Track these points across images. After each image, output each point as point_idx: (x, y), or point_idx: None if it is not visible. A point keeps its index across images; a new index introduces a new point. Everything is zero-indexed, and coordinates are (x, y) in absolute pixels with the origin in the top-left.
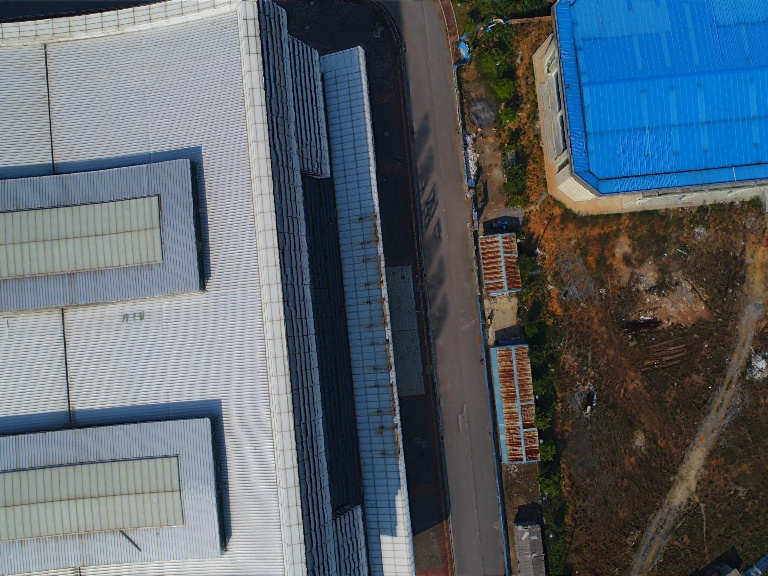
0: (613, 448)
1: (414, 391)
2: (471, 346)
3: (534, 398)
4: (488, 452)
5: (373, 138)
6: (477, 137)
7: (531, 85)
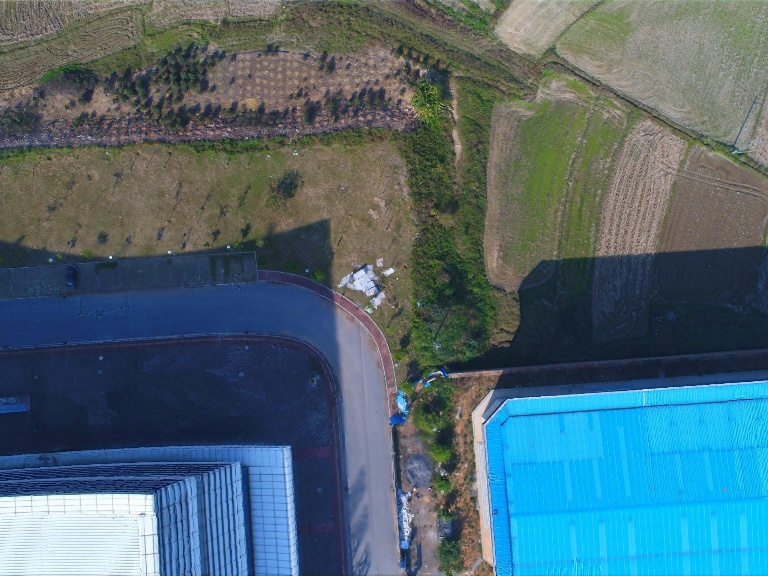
0: None
1: None
2: None
3: None
4: None
5: (297, 540)
6: (412, 496)
7: (469, 444)
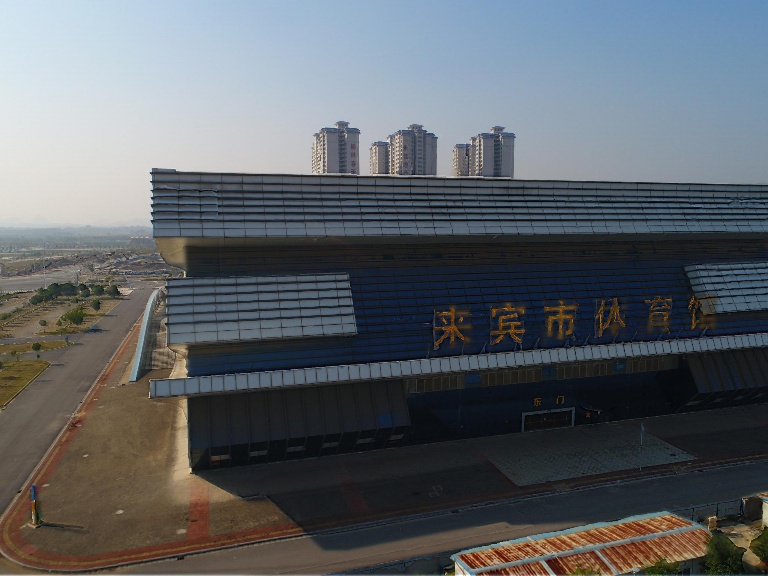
0: None
1: (515, 477)
2: None
3: (628, 573)
4: None
5: None
6: None
7: None
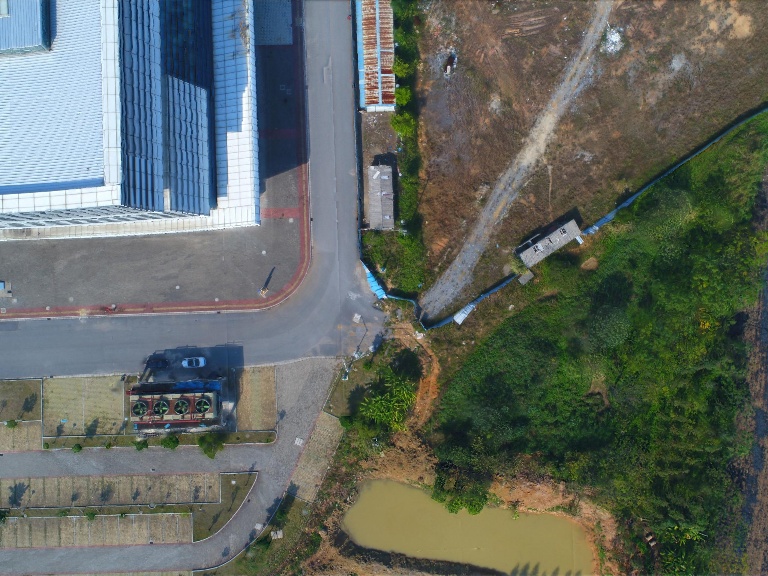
0: (469, 108)
1: (282, 41)
2: (340, 2)
3: (394, 47)
4: (350, 103)
5: None
6: None
7: None
